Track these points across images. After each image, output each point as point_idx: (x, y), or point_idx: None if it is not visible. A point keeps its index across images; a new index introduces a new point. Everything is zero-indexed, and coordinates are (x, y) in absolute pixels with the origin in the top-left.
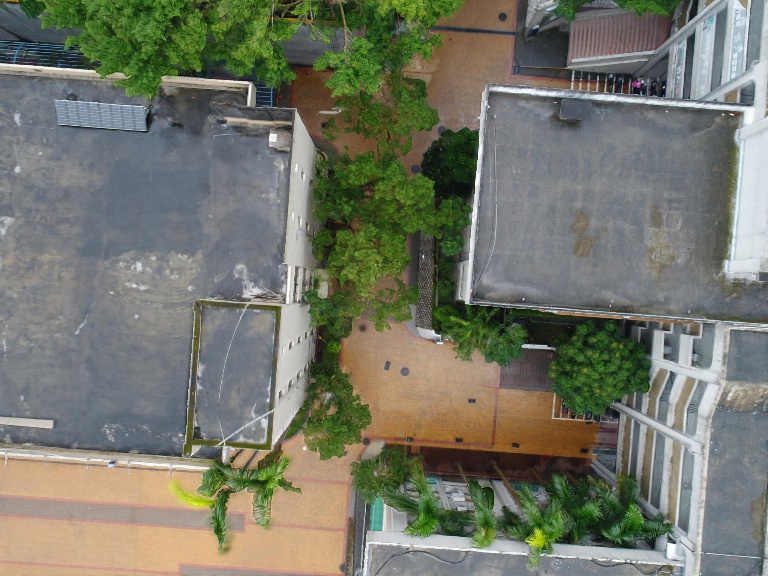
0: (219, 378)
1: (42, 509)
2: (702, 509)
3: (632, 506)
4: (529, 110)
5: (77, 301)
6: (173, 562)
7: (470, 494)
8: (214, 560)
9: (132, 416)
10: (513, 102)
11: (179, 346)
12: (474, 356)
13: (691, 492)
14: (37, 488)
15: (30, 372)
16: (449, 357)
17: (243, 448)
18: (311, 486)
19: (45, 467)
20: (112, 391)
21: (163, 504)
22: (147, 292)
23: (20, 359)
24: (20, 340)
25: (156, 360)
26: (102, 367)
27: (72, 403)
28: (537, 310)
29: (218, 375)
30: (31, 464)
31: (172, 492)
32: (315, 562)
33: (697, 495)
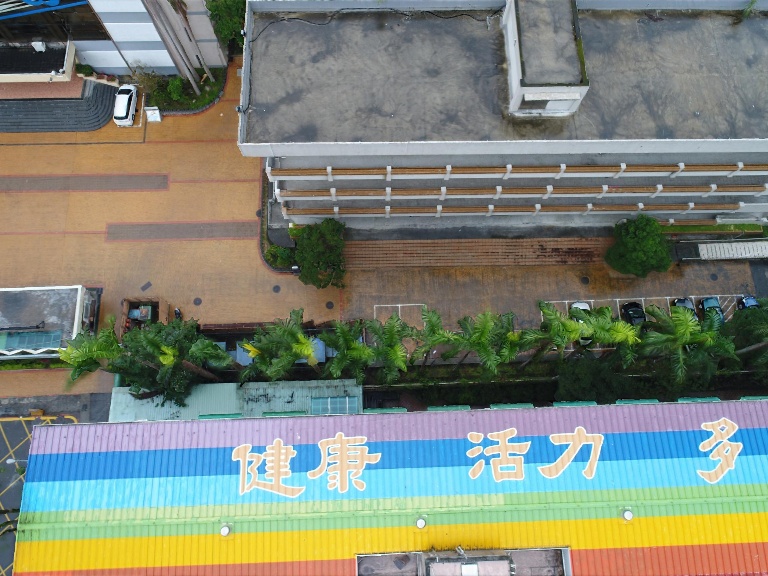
0: None
1: None
2: None
3: None
4: None
5: None
6: (101, 222)
7: None
8: (140, 217)
9: None
10: None
11: None
12: None
13: None
14: None
15: None
16: None
17: None
18: (228, 145)
19: None
20: None
21: (94, 172)
22: None
23: None
24: None
25: None
26: None
27: None
28: None
29: None
30: None
31: (103, 161)
32: (233, 211)
33: None
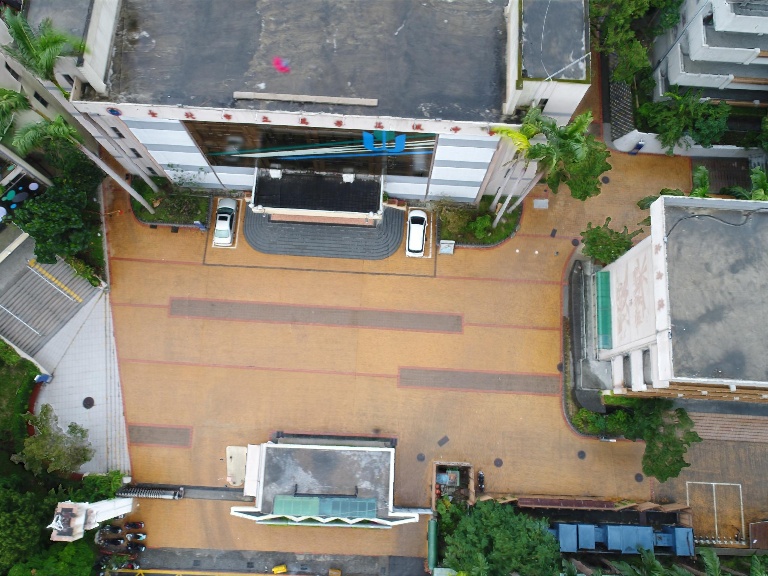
0: (540, 33)
1: (267, 314)
2: None
3: None
4: None
5: (396, 11)
6: (393, 365)
7: (729, 191)
8: (433, 362)
9: (444, 97)
10: None
11: (482, 43)
12: (666, 165)
13: None
14: (263, 293)
15: (356, 64)
16: (644, 167)
17: (567, 82)
18: (525, 287)
19: (272, 273)
20: (427, 77)
21: (384, 307)
22: (454, 4)
23: (348, 54)
24: (348, 40)
25: (464, 53)
26: (418, 59)
27: (392, 87)
28: None
29: (539, 31)
30: (259, 271)
31: (392, 295)
32: (533, 362)
33: None
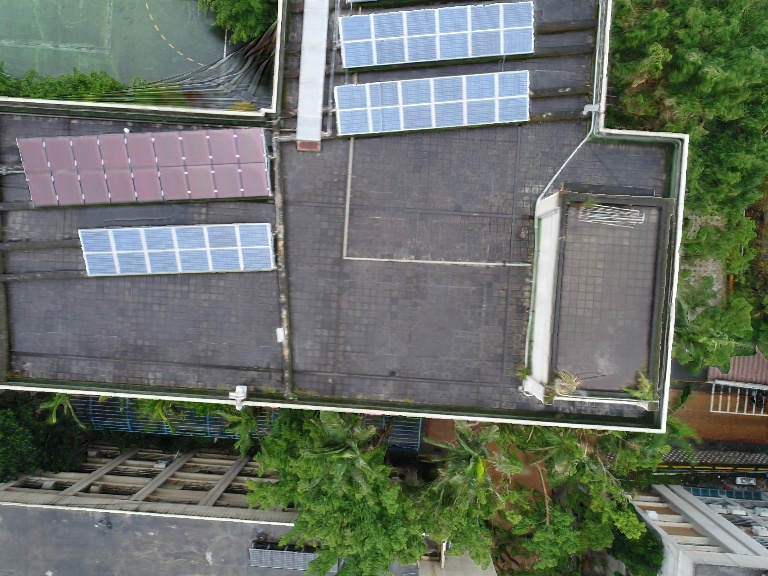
0: None
1: None
2: None
3: None
4: (730, 575)
5: None
6: None
7: None
8: None
9: None
10: (714, 568)
11: None
12: None
13: None
14: None
15: None
16: None
17: None
18: None
19: None
20: None
21: None
22: None
23: None
24: None
25: None
26: None
27: None
28: None
29: None
30: None
31: None
32: None
33: None
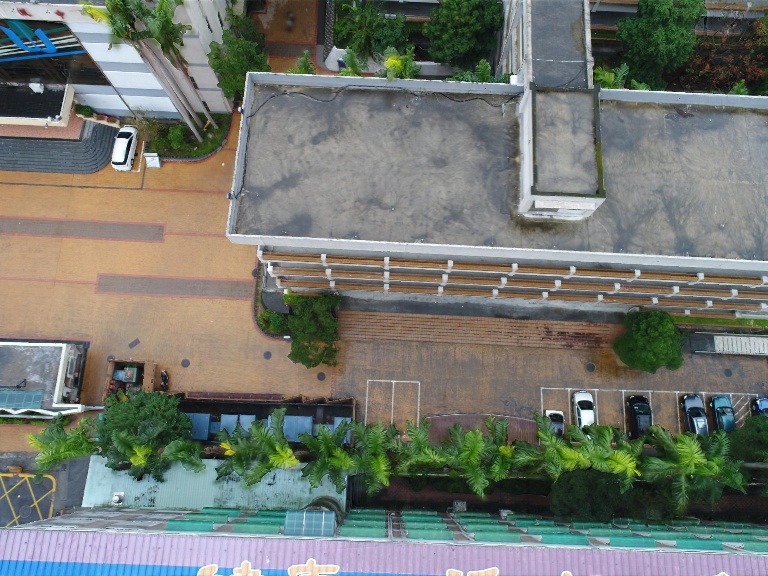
0: None
1: None
2: (529, 27)
3: None
4: None
5: None
6: (92, 272)
7: None
8: (132, 269)
9: None
10: None
11: None
12: None
13: (523, 28)
14: None
15: None
16: None
17: None
18: None
19: None
20: None
21: (89, 218)
22: None
23: None
24: None
25: None
26: None
27: None
28: (421, 25)
29: None
30: None
31: (99, 207)
32: (229, 269)
33: (525, 21)
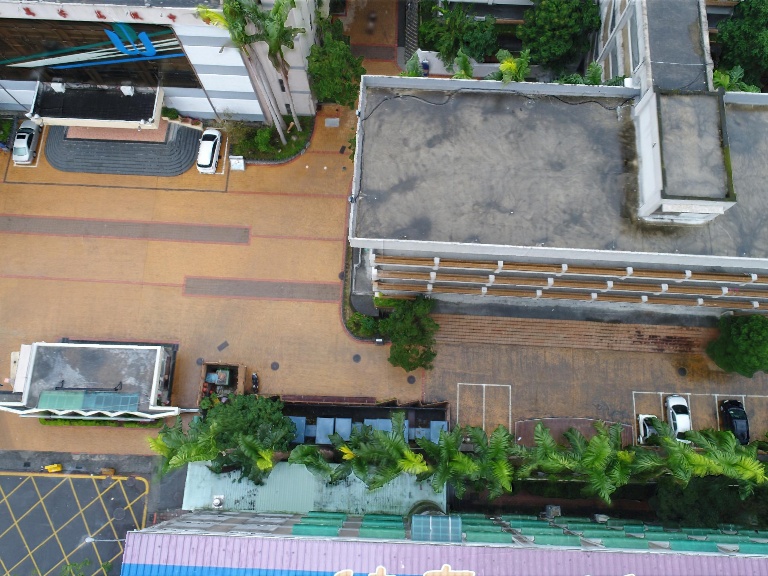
0: None
1: (61, 227)
2: (646, 30)
3: (591, 63)
4: None
5: None
6: (179, 275)
7: None
8: (219, 272)
9: None
10: None
11: None
12: None
13: (637, 30)
14: (59, 209)
15: None
16: None
17: None
18: (313, 200)
19: (69, 190)
20: None
21: (174, 220)
22: None
23: None
24: None
25: None
26: None
27: None
28: (506, 27)
29: None
30: (57, 187)
31: (184, 209)
32: (315, 271)
33: (641, 24)
